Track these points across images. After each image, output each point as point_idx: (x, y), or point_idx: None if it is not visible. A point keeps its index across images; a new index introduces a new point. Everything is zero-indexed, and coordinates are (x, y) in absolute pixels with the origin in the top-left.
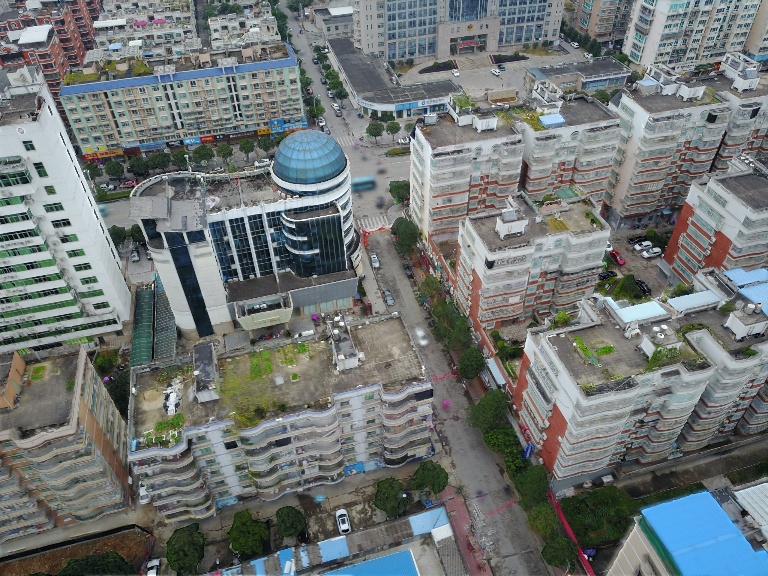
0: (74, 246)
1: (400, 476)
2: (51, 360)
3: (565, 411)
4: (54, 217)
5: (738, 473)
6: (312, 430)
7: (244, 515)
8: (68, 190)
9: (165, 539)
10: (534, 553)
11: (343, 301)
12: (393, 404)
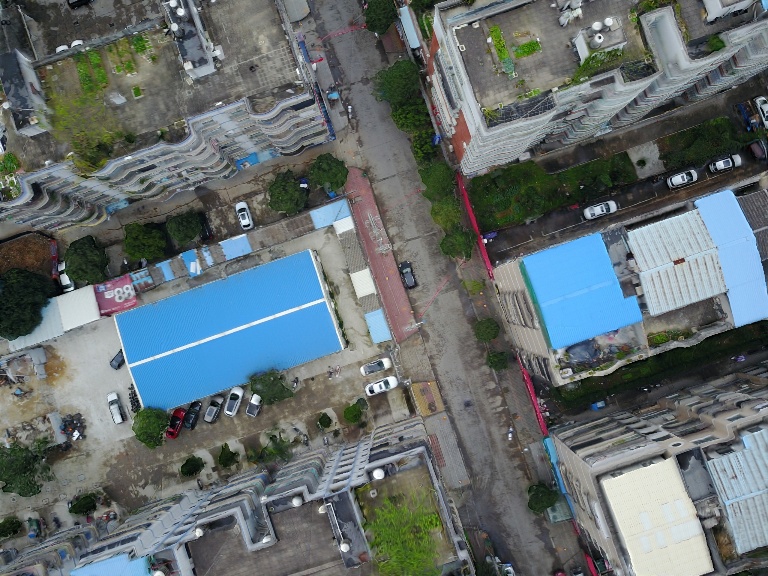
0: None
1: (301, 160)
2: None
3: (469, 125)
4: None
5: (670, 138)
6: (176, 155)
7: (134, 229)
8: None
9: (68, 241)
10: (437, 235)
11: None
12: (266, 120)
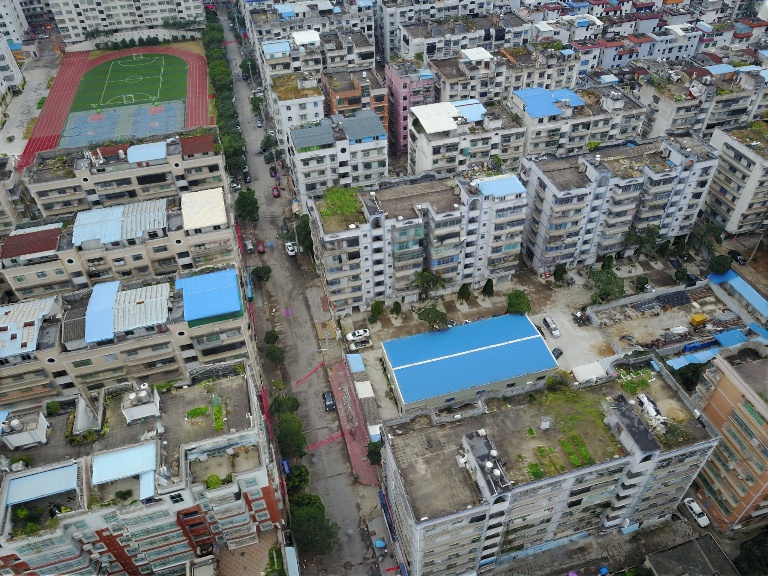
0: None
1: None
2: None
3: None
4: None
5: None
6: None
7: None
8: None
9: None
10: None
11: None
12: None
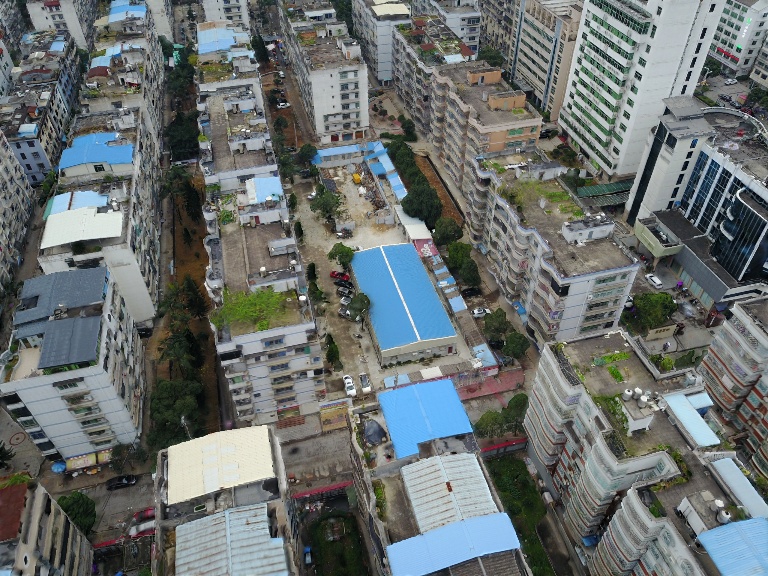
0: (633, 97)
1: None
2: (529, 114)
3: None
4: (638, 69)
5: None
6: None
7: (468, 246)
8: (654, 55)
9: None
10: None
11: (708, 298)
12: None
